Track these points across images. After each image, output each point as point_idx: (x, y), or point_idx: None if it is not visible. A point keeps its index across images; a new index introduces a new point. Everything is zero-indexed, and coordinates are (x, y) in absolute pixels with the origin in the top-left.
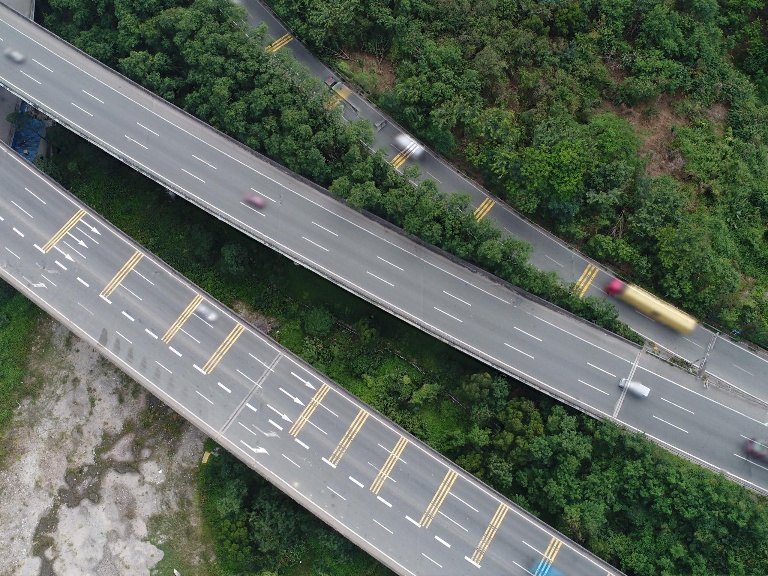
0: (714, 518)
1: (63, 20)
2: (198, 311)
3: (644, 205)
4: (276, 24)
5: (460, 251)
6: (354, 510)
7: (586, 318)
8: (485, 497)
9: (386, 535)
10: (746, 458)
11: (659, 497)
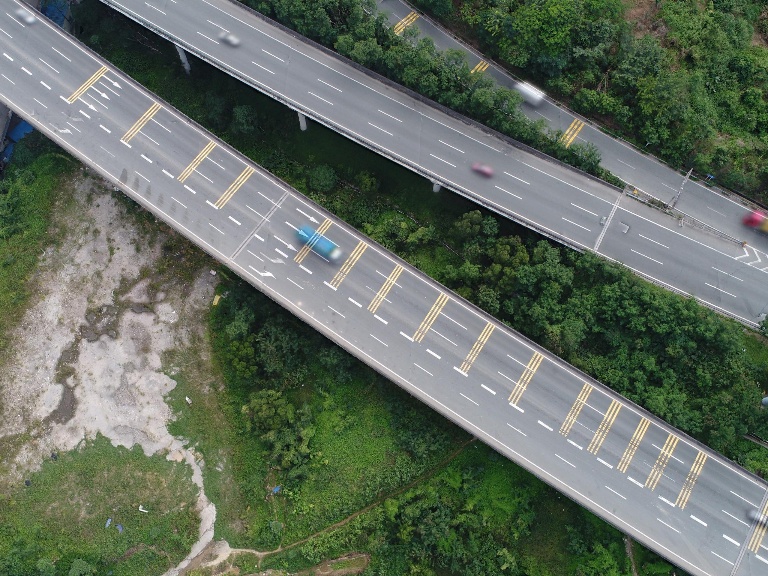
0: (684, 334)
1: None
2: (211, 155)
3: (627, 58)
4: None
5: (455, 100)
6: (353, 326)
7: (571, 164)
8: (474, 317)
9: (382, 348)
10: (716, 287)
11: (634, 316)
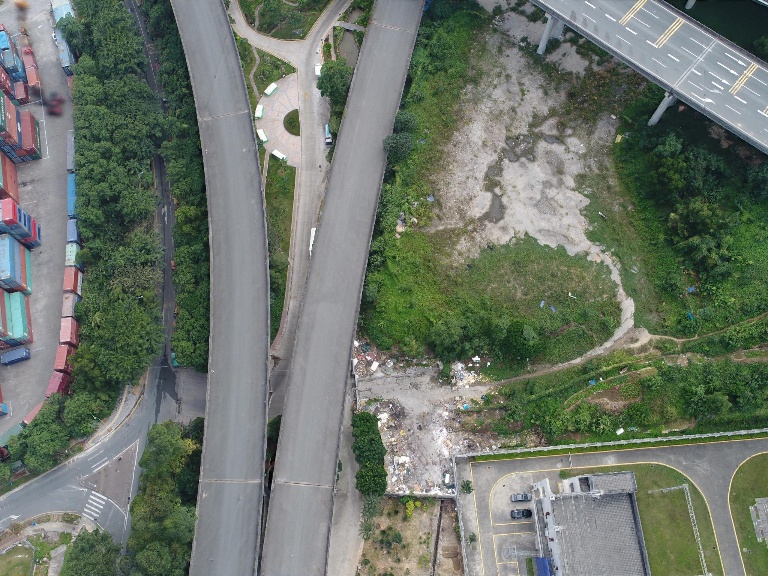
0: None
1: None
2: (645, 7)
3: None
4: None
5: None
6: None
7: None
8: None
9: None
10: None
11: None
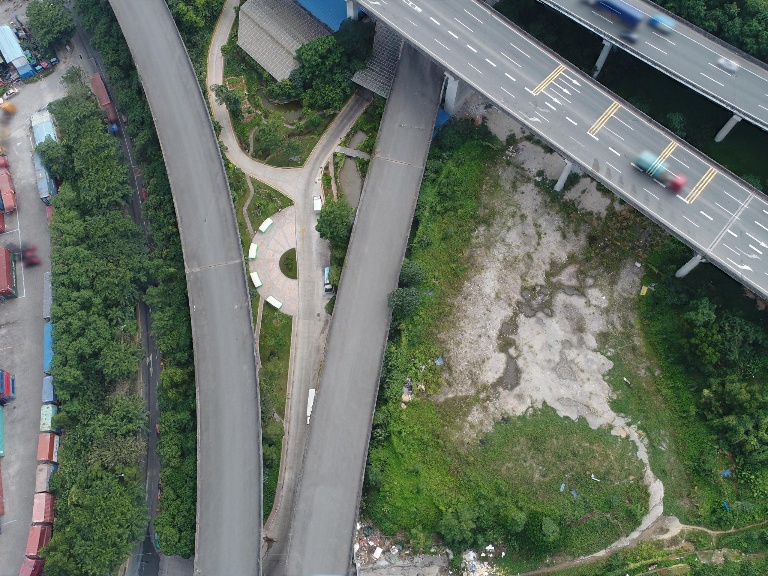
0: None
1: None
2: (674, 154)
3: None
4: None
5: None
6: None
7: None
8: None
9: None
10: None
11: None
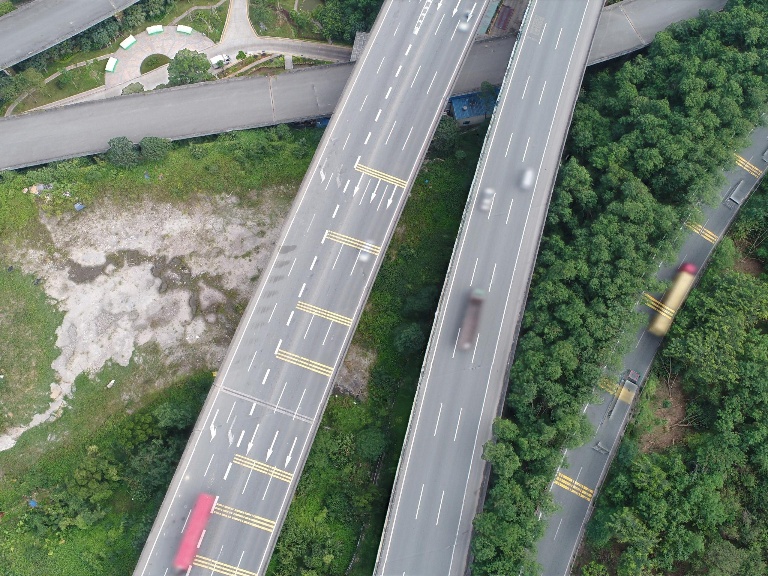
0: None
1: (610, 88)
2: (336, 325)
3: None
4: (682, 295)
5: None
6: (174, 544)
7: None
8: None
9: None
10: None
11: None
